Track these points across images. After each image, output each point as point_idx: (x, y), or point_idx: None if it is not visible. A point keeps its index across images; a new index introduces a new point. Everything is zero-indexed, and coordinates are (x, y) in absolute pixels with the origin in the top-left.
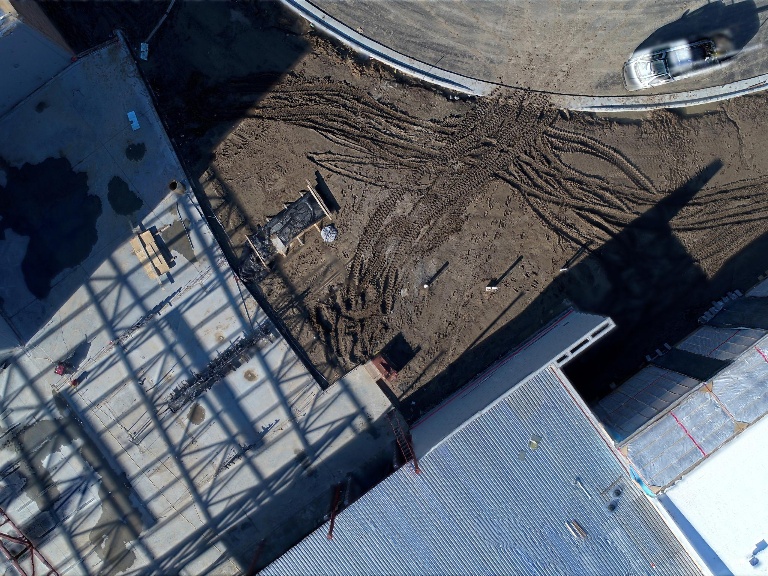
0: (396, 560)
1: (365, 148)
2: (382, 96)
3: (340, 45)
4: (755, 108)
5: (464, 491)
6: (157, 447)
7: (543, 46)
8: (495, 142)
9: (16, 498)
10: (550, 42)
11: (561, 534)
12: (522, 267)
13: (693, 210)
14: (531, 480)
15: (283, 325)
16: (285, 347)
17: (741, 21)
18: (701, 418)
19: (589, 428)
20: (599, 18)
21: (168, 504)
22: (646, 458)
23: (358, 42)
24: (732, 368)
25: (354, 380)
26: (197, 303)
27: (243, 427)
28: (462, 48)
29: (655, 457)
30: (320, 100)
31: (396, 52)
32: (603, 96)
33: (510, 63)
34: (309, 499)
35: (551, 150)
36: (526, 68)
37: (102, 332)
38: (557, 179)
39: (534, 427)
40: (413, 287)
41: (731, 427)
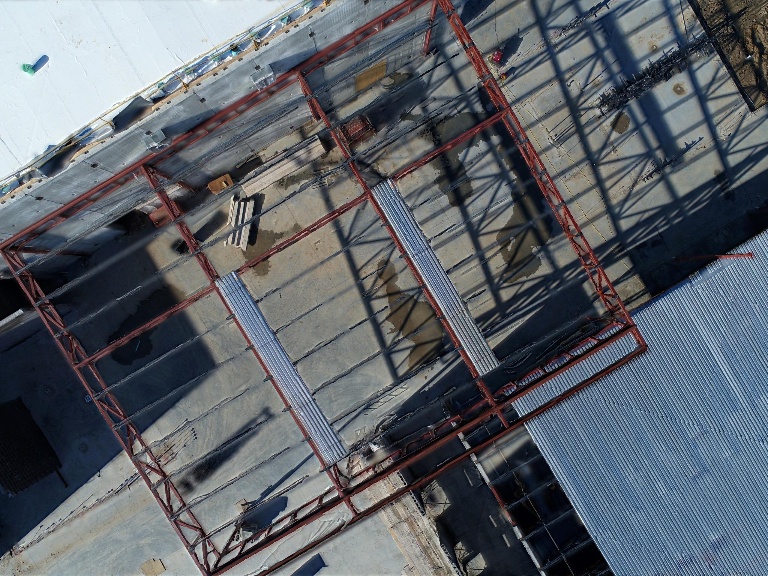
0: None
1: None
2: None
3: None
4: None
5: None
6: (576, 152)
7: None
8: None
9: (428, 189)
10: None
11: None
12: None
13: None
14: None
15: (715, 42)
16: (718, 63)
17: None
18: None
19: None
20: None
21: (580, 212)
22: None
23: None
24: None
25: None
26: (635, 8)
27: (666, 140)
28: None
29: None
30: None
31: None
32: None
33: None
34: (723, 222)
35: None
36: None
37: (536, 28)
38: None
39: None
40: None
41: None
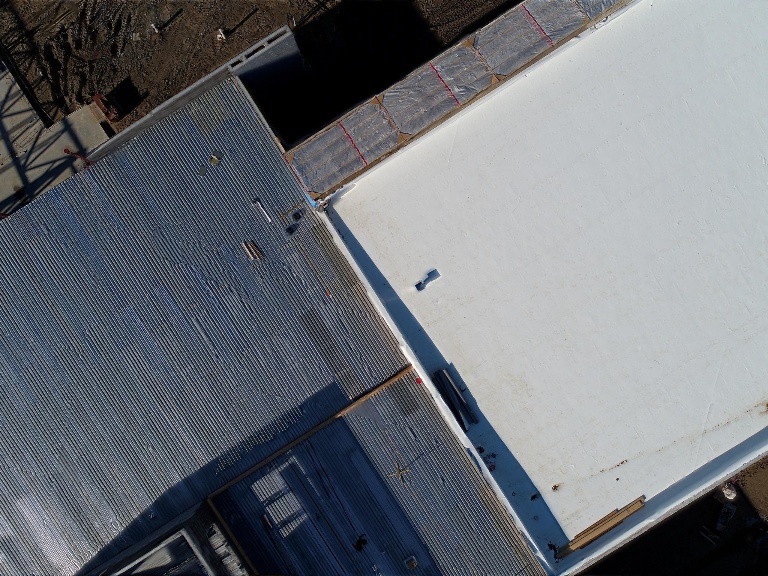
0: (67, 266)
1: None
2: None
3: None
4: None
5: (141, 202)
6: None
7: None
8: None
9: None
10: None
11: (238, 255)
12: (256, 19)
13: None
14: (210, 197)
15: (12, 60)
16: (10, 81)
17: None
18: (368, 129)
19: (273, 149)
20: None
21: None
22: (310, 166)
23: None
24: (405, 83)
25: (78, 120)
26: None
27: None
28: None
29: (319, 165)
30: None
31: None
32: None
33: None
34: None
35: None
36: None
37: None
38: None
39: (217, 143)
40: (145, 31)
41: (395, 138)
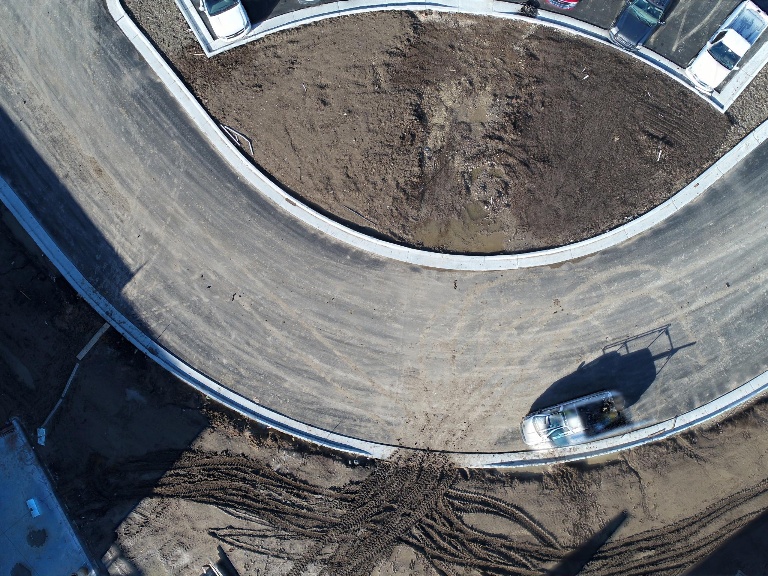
0: None
1: (266, 521)
2: (281, 466)
3: (237, 416)
4: (656, 457)
5: None
6: None
7: (440, 406)
8: (396, 507)
9: None
10: (447, 401)
11: None
12: None
13: (599, 563)
14: None
15: None
16: None
17: (637, 370)
18: None
19: None
20: (495, 375)
21: None
22: None
23: (255, 412)
24: None
25: None
26: None
27: None
28: (359, 412)
29: None
30: (219, 475)
31: (293, 420)
32: (503, 452)
33: (408, 424)
34: None
35: (452, 512)
36: (424, 428)
37: None
38: (460, 540)
39: None
40: None
41: None
